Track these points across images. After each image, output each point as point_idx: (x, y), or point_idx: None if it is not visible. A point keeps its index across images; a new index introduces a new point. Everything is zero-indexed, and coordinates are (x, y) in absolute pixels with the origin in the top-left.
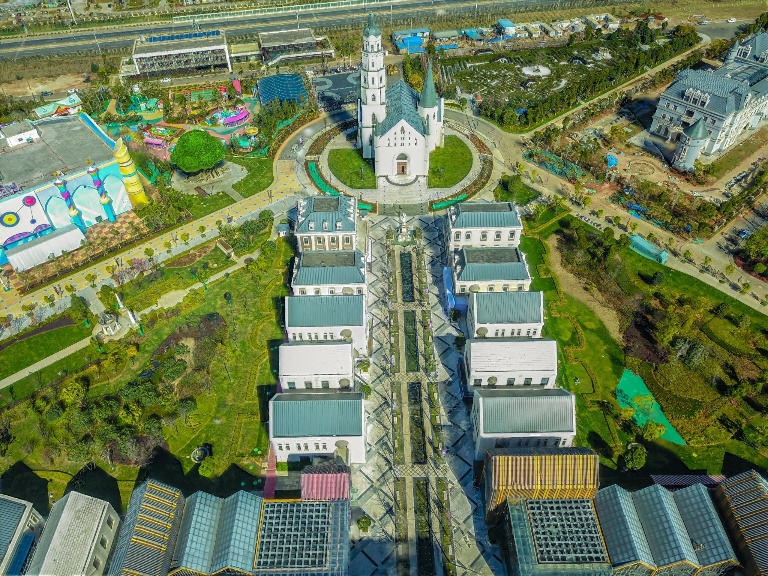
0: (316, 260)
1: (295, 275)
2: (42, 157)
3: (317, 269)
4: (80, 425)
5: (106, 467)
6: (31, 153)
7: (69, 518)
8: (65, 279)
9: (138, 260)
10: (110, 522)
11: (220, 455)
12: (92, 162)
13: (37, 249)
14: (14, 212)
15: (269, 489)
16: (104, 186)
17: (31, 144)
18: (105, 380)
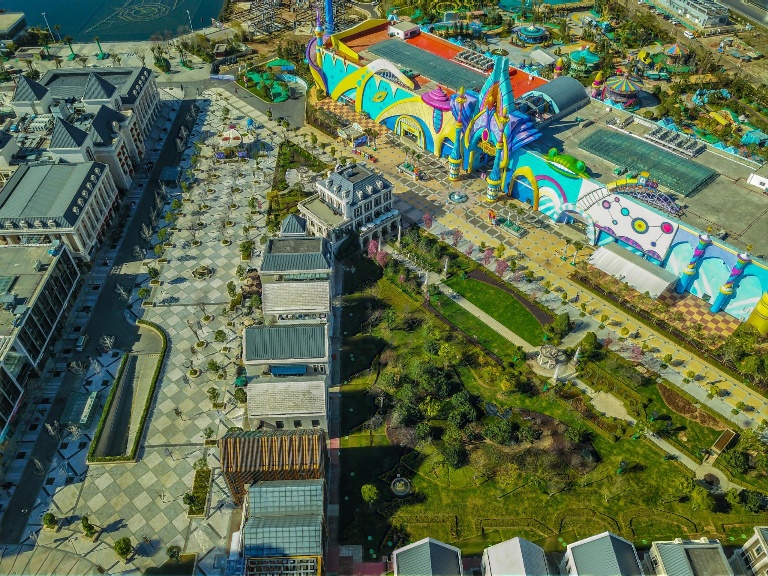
0: (711, 570)
1: (672, 543)
2: (745, 211)
3: (689, 574)
4: (414, 370)
5: (384, 407)
6: (747, 200)
7: (302, 388)
8: (603, 301)
9: (638, 351)
10: (316, 423)
11: (402, 507)
12: (764, 253)
13: (623, 263)
14: (649, 224)
15: (364, 568)
16: (742, 280)
17: (763, 194)
18: (478, 375)
